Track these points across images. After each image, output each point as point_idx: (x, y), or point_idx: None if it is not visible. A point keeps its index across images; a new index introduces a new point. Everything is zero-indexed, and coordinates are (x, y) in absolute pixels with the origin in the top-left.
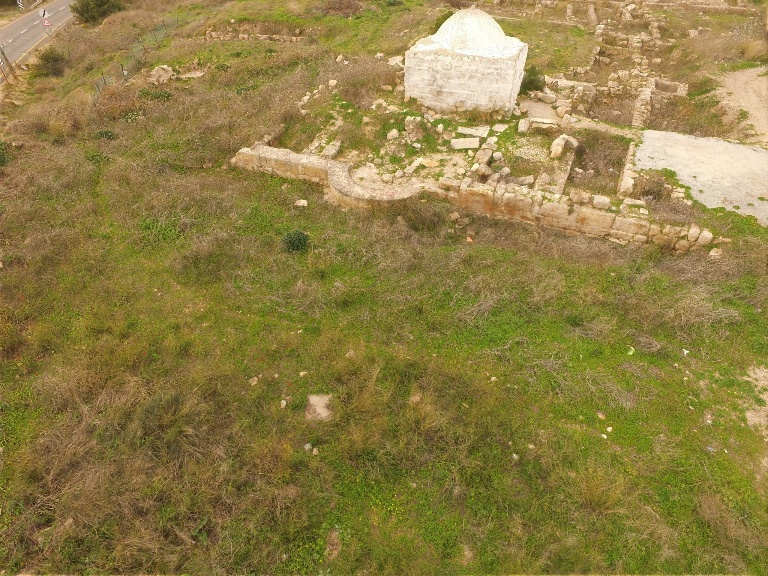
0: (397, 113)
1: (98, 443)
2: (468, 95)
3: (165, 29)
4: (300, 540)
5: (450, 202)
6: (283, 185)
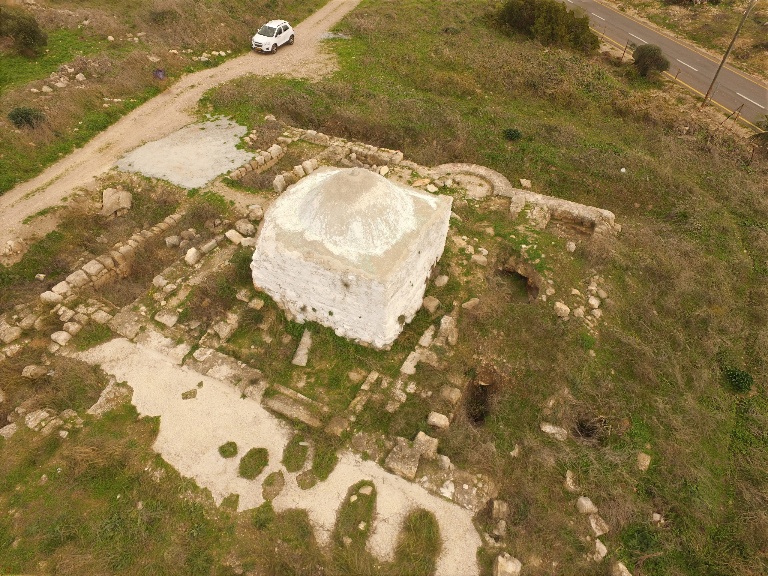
0: (454, 222)
1: None
2: None
3: None
4: None
5: None
6: None
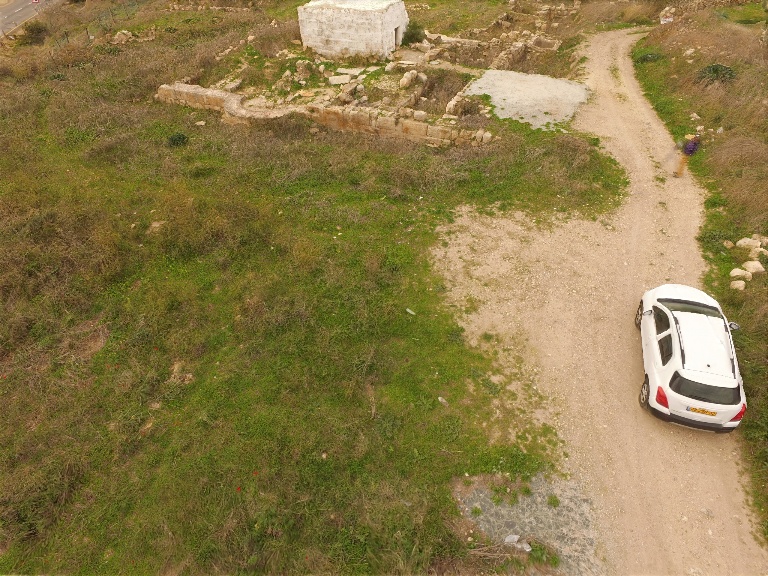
0: (292, 58)
1: (2, 239)
2: (350, 43)
3: (137, 4)
4: (115, 283)
5: (314, 121)
6: (192, 113)
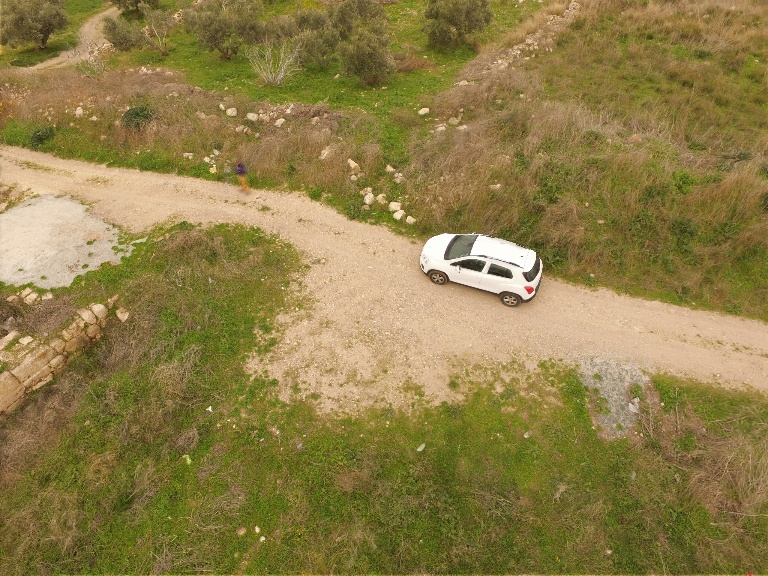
0: None
1: None
2: None
3: None
4: None
5: None
6: None
